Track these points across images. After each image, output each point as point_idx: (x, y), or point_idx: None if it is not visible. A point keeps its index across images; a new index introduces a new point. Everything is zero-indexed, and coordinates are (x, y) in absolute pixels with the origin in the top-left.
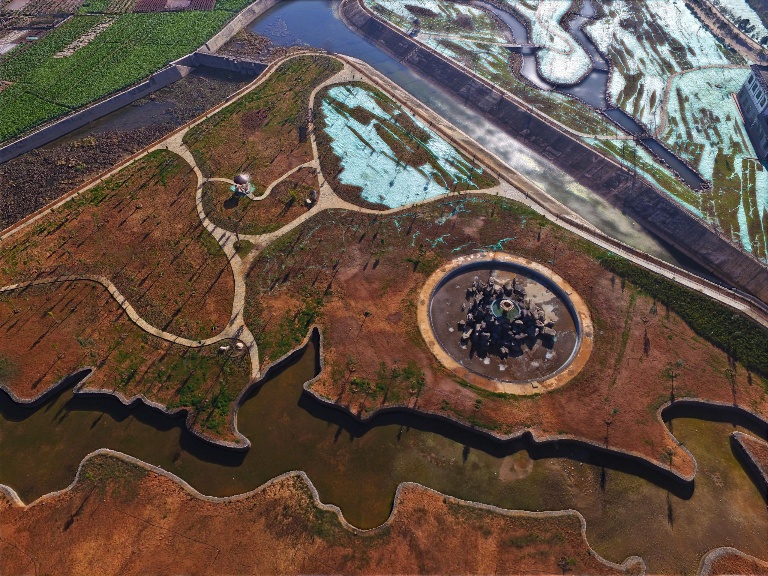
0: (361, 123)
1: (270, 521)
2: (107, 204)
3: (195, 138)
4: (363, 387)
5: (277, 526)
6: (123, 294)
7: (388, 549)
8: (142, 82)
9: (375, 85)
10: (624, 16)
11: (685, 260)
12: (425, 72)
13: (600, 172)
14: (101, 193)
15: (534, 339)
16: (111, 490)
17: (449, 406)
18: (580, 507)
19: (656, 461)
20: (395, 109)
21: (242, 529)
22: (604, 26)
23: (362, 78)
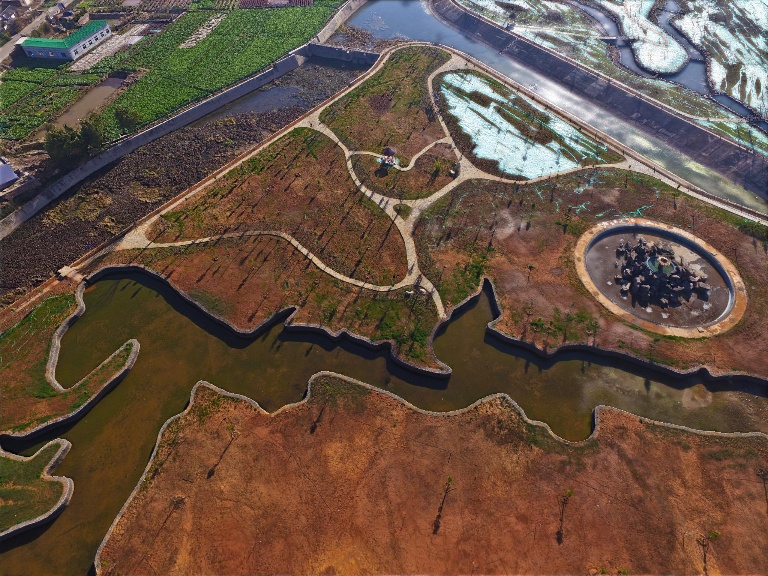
0: (482, 106)
1: (489, 432)
2: (268, 173)
3: (331, 118)
4: (543, 327)
5: (496, 436)
6: (306, 247)
7: (600, 457)
8: (266, 69)
9: (485, 73)
10: (711, 11)
11: None
12: (526, 62)
13: (717, 151)
14: (259, 163)
15: (689, 292)
16: (342, 403)
17: (626, 345)
18: (764, 432)
19: None
20: (510, 94)
21: (466, 437)
22: (693, 20)
23: (472, 66)
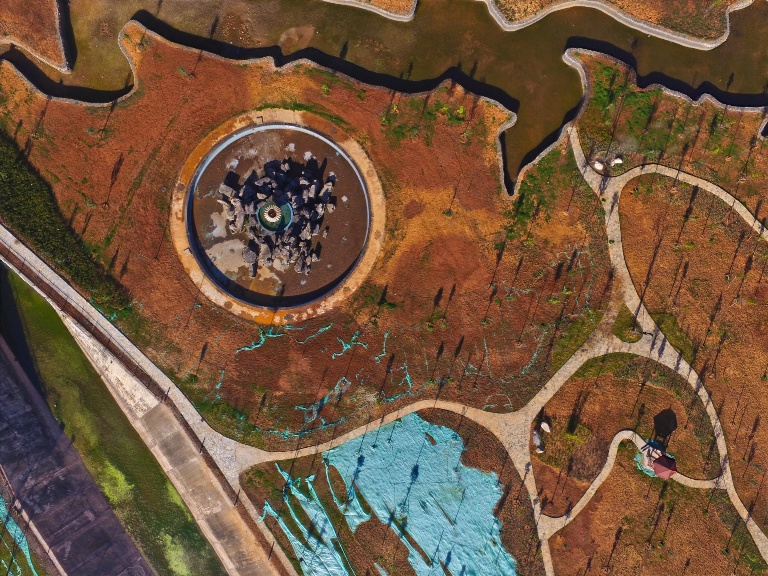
0: None
1: None
2: None
3: None
4: (451, 115)
5: None
6: (767, 244)
7: None
8: None
9: None
10: None
11: (11, 335)
12: None
13: (68, 518)
14: None
15: None
16: (689, 5)
17: (357, 93)
18: (244, 2)
19: (157, 38)
20: None
21: None
22: None
23: None
